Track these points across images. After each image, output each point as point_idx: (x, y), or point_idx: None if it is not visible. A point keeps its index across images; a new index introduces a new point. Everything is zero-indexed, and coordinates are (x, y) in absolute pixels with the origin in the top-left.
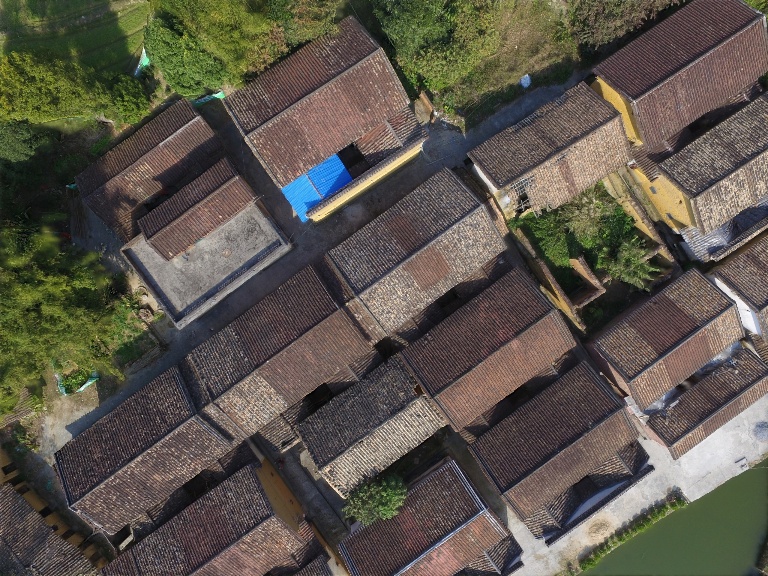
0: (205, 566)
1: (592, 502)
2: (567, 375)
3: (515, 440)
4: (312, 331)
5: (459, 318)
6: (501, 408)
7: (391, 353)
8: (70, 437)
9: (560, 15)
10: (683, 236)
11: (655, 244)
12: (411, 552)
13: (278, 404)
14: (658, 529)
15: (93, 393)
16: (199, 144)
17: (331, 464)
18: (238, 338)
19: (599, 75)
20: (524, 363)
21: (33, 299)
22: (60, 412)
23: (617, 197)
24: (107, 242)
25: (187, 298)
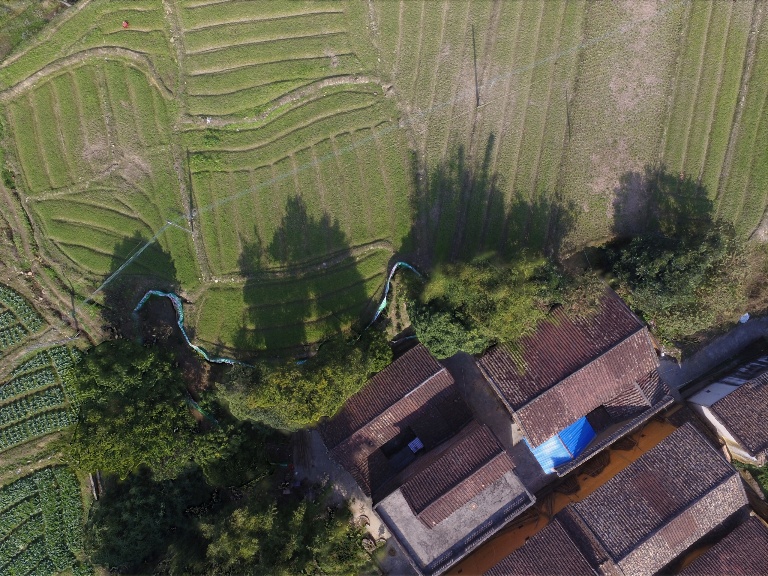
0: None
1: None
2: None
3: None
4: None
5: (700, 569)
6: None
7: None
8: None
9: None
10: None
11: None
12: None
13: None
14: None
15: None
16: (439, 391)
17: None
18: None
19: None
20: None
21: None
22: None
23: None
24: (330, 471)
25: (434, 551)
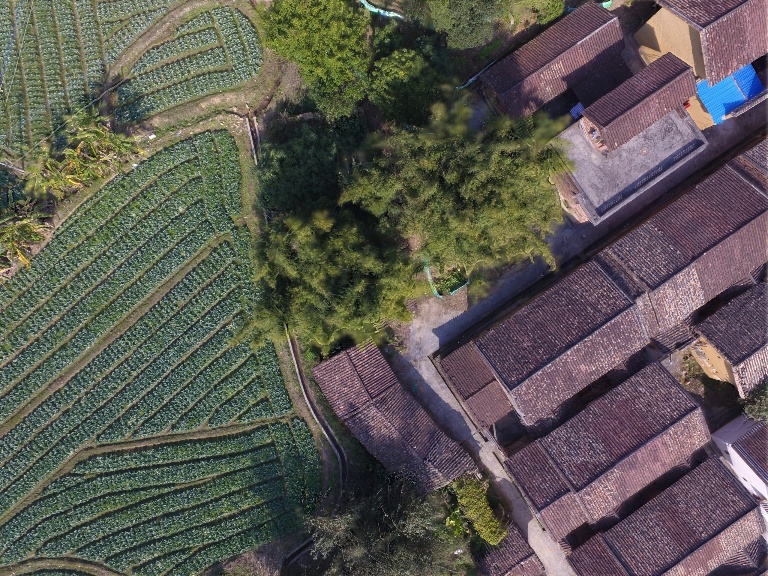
0: (631, 456)
1: None
2: None
3: None
4: (748, 225)
5: None
6: None
7: None
8: (436, 340)
9: None
10: None
11: None
12: None
13: (698, 300)
14: None
15: (463, 297)
16: (608, 46)
17: (745, 361)
18: (662, 233)
19: None
20: None
21: None
22: (428, 315)
23: None
24: None
25: (604, 195)
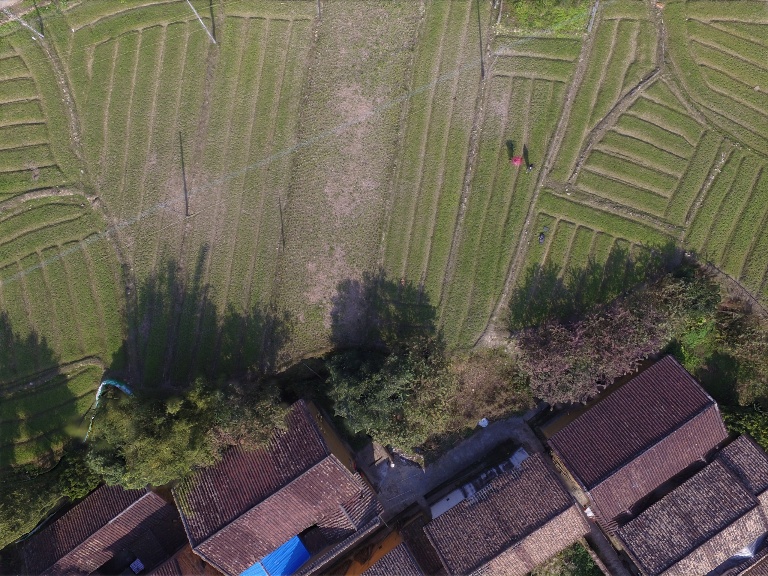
0: None
1: None
2: None
3: None
4: None
5: None
6: None
7: None
8: None
9: (516, 359)
10: None
11: None
12: None
13: None
14: None
15: None
16: (150, 514)
17: None
18: None
19: (554, 450)
20: None
21: None
22: None
23: None
24: None
25: None
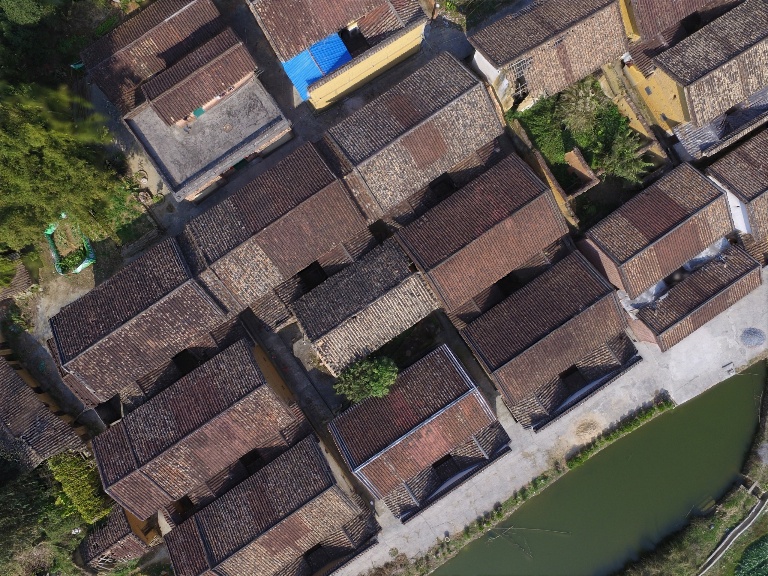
0: (195, 432)
1: (580, 392)
2: (559, 263)
3: (506, 324)
4: (310, 201)
5: (455, 200)
6: (493, 297)
7: (387, 236)
8: None
9: None
10: (676, 133)
11: (649, 140)
12: (400, 428)
13: (273, 276)
14: (645, 433)
15: (89, 276)
16: (204, 24)
17: (324, 338)
18: (236, 209)
19: None
20: (517, 245)
21: (35, 140)
22: (56, 294)
23: (613, 96)
24: (109, 125)
25: (187, 171)
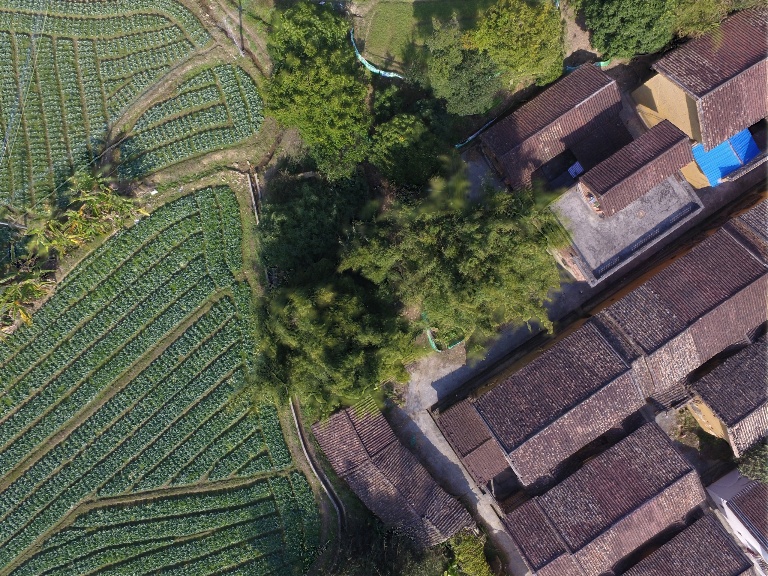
0: (626, 517)
1: None
2: None
3: None
4: (743, 291)
5: None
6: None
7: None
8: (435, 394)
9: None
10: None
11: None
12: None
13: (693, 362)
14: None
15: (461, 351)
16: (606, 108)
17: (740, 422)
18: (659, 296)
19: None
20: None
21: None
22: (426, 369)
23: None
24: (484, 203)
25: (601, 257)
